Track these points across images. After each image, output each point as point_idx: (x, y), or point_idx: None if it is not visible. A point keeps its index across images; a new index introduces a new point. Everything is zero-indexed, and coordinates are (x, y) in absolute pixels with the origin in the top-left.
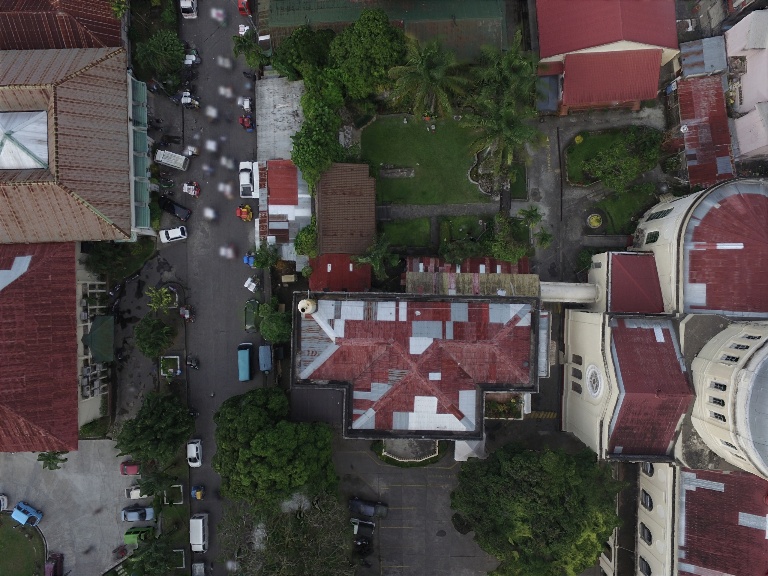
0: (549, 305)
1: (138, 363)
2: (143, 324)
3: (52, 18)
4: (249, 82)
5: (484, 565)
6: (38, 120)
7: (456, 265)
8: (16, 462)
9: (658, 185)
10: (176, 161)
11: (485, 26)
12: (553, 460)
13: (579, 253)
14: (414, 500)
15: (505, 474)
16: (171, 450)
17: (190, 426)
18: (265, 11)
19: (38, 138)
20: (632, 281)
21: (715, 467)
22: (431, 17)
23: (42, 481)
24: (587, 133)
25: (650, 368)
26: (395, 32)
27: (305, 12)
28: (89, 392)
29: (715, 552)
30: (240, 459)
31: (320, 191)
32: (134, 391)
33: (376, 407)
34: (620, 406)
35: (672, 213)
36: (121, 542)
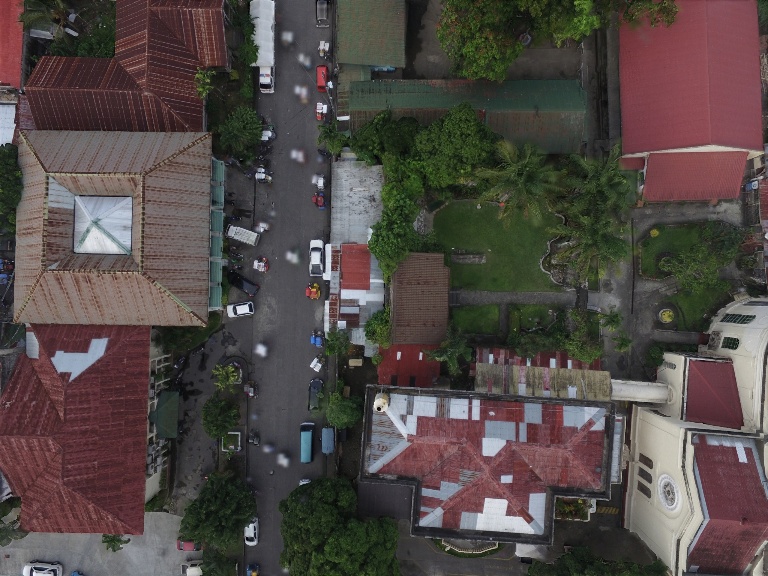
0: None
1: (198, 436)
2: (211, 405)
3: (137, 97)
4: (323, 159)
5: None
6: (124, 206)
7: (526, 358)
8: None
9: (732, 282)
10: (248, 238)
11: (567, 118)
12: None
13: (650, 349)
14: None
15: None
16: (235, 538)
17: (253, 510)
18: (345, 92)
19: (123, 224)
20: (710, 390)
21: None
22: (513, 107)
23: (97, 551)
24: (663, 228)
25: (734, 492)
26: (483, 130)
27: (386, 96)
28: (153, 470)
29: None
30: (314, 564)
31: (396, 281)
32: (193, 464)
33: (445, 506)
34: (702, 530)
35: (754, 323)
36: None
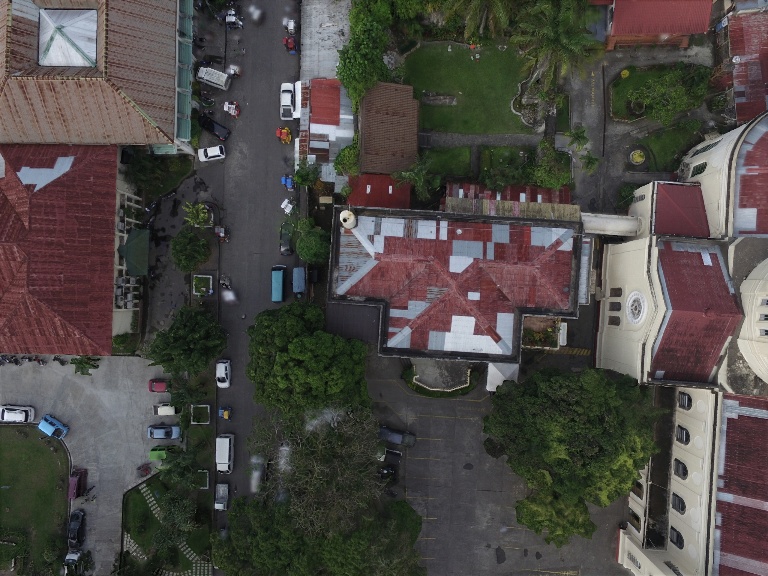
0: None
1: (170, 282)
2: (180, 236)
3: None
4: (294, 5)
5: (511, 501)
6: (88, 18)
7: (496, 192)
8: (45, 375)
9: (703, 124)
10: (218, 78)
11: None
12: (595, 378)
13: (621, 188)
14: (442, 431)
15: (542, 395)
16: (204, 360)
17: (222, 341)
18: None
19: (87, 36)
20: (678, 210)
21: (760, 393)
22: None
23: (70, 395)
24: (634, 67)
25: (698, 289)
26: None
27: None
28: (123, 303)
29: (756, 481)
30: (278, 361)
31: (364, 109)
32: (165, 310)
33: (413, 325)
34: (666, 325)
35: (721, 142)
36: (146, 460)
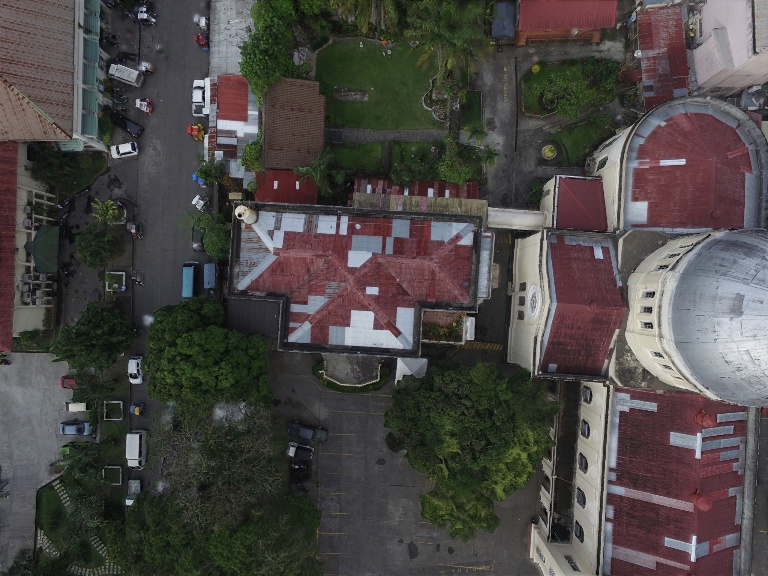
0: (499, 235)
1: (84, 278)
2: (86, 232)
3: None
4: (207, 2)
5: None
6: None
7: (404, 188)
8: None
9: (615, 119)
10: (129, 75)
11: None
12: (482, 371)
13: (531, 183)
14: (355, 427)
15: (437, 389)
16: (105, 356)
17: (128, 337)
18: None
19: None
20: (578, 204)
21: (648, 386)
22: None
23: None
24: (544, 62)
25: (585, 282)
26: None
27: None
28: (30, 299)
29: (646, 473)
30: (165, 356)
31: (267, 104)
32: (79, 306)
33: (312, 320)
34: (552, 318)
35: (621, 136)
36: (59, 457)
